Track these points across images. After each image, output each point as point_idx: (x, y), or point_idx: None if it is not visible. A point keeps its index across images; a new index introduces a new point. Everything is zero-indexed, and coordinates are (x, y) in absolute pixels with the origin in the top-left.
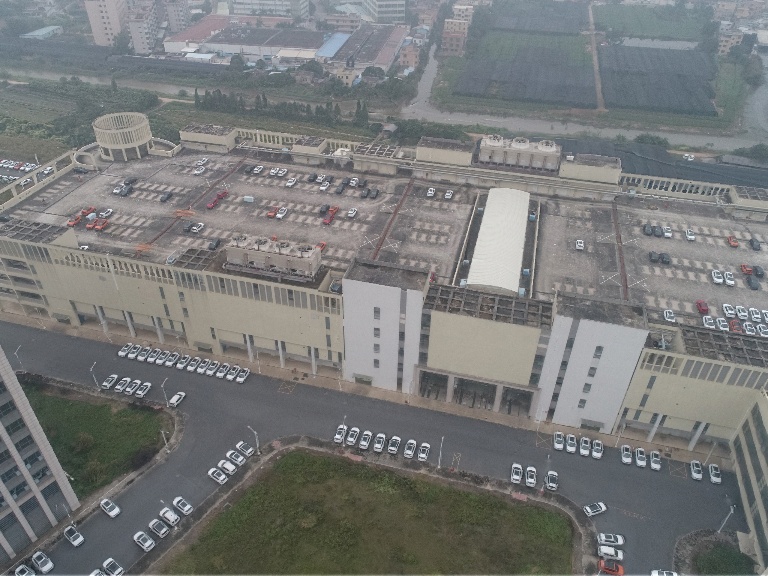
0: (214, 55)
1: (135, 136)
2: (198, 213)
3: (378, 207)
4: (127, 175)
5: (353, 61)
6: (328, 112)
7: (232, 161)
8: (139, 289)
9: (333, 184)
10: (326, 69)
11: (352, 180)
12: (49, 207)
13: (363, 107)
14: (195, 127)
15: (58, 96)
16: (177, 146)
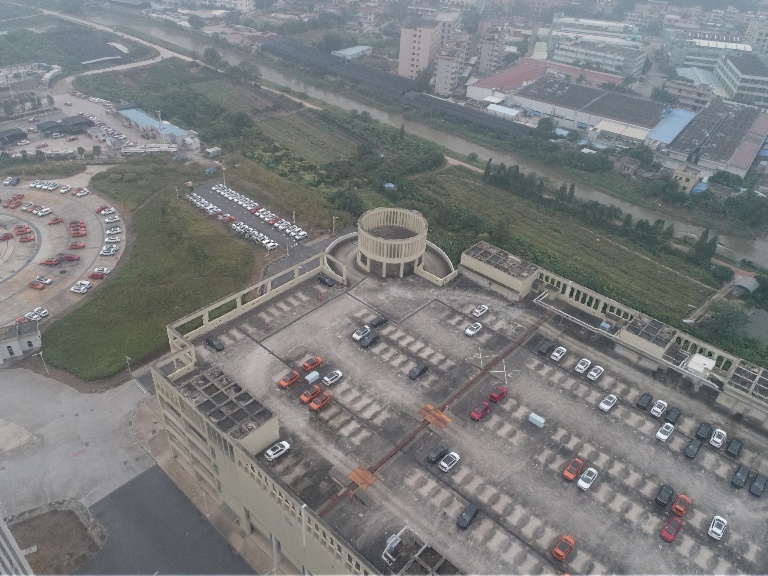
0: (520, 112)
1: (404, 250)
2: (455, 423)
3: (766, 526)
4: (378, 305)
5: (698, 156)
6: (655, 231)
7: (522, 321)
8: (332, 568)
9: (679, 428)
10: (657, 158)
11: (717, 436)
12: (270, 336)
13: (711, 240)
14: (484, 251)
15: (343, 132)
16: (453, 272)
